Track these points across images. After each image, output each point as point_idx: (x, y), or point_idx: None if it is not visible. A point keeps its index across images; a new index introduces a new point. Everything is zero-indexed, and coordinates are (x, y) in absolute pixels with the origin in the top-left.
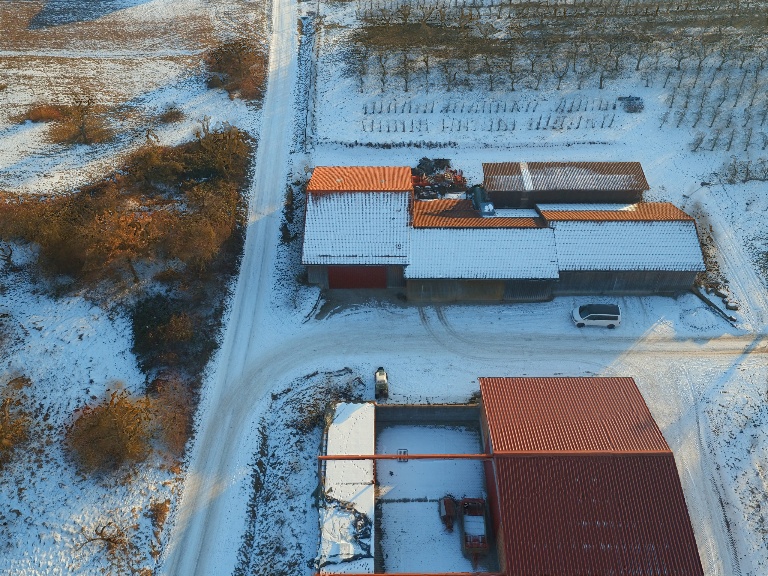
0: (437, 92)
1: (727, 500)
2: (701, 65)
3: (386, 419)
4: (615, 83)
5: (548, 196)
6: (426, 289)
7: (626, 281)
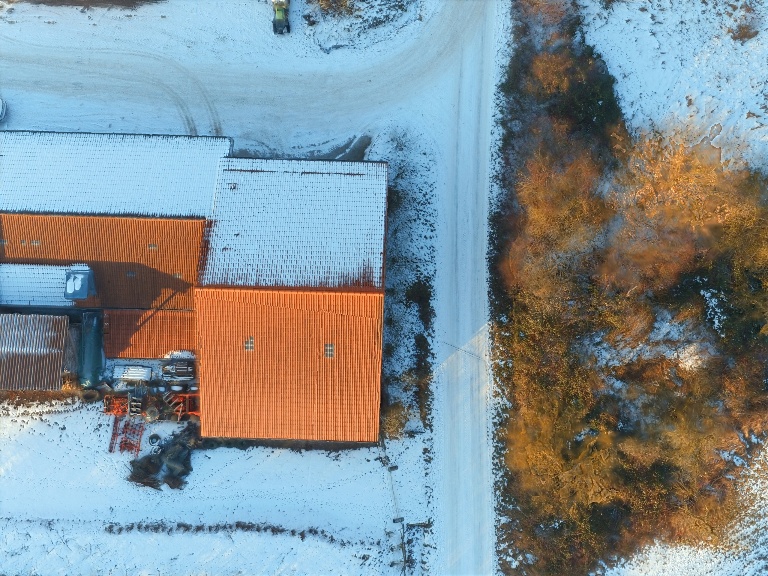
0: None
1: None
2: None
3: None
4: None
5: None
6: None
7: None
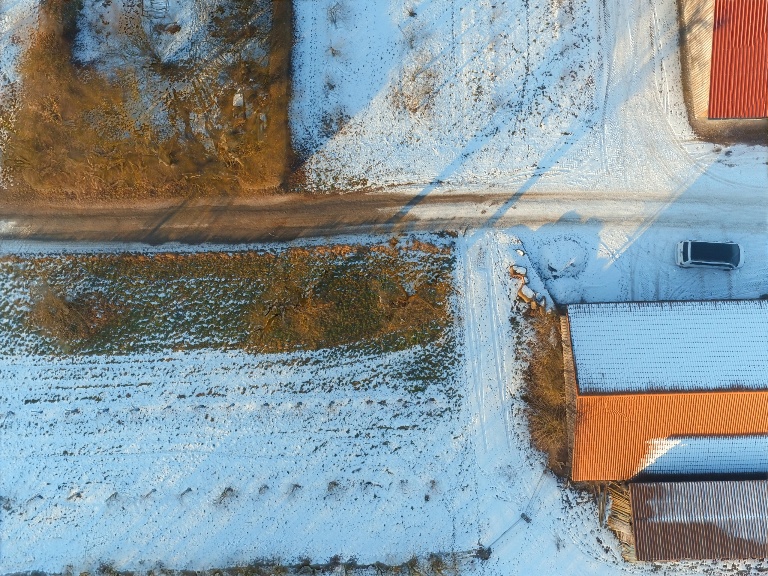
0: None
1: (600, 2)
2: None
3: None
4: None
5: None
6: None
7: None
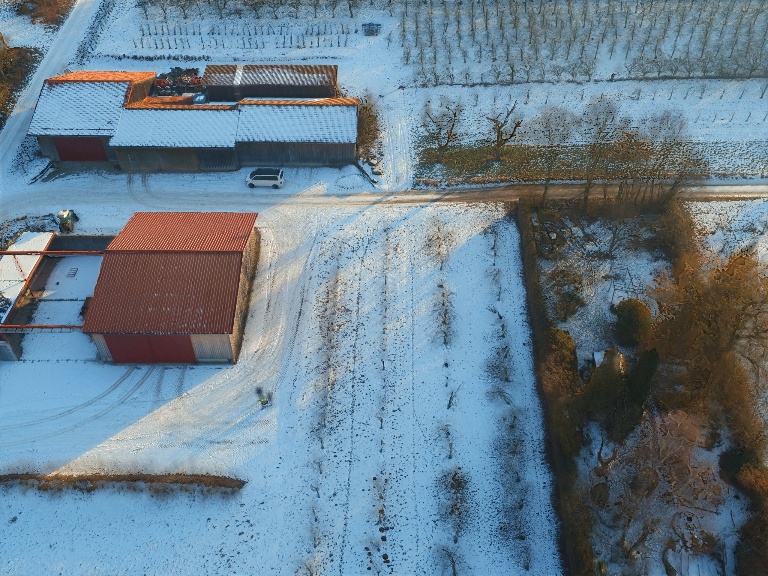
0: (211, 19)
1: (306, 298)
2: (446, 0)
3: (70, 249)
4: (366, 13)
5: (256, 91)
6: (133, 158)
7: (298, 154)
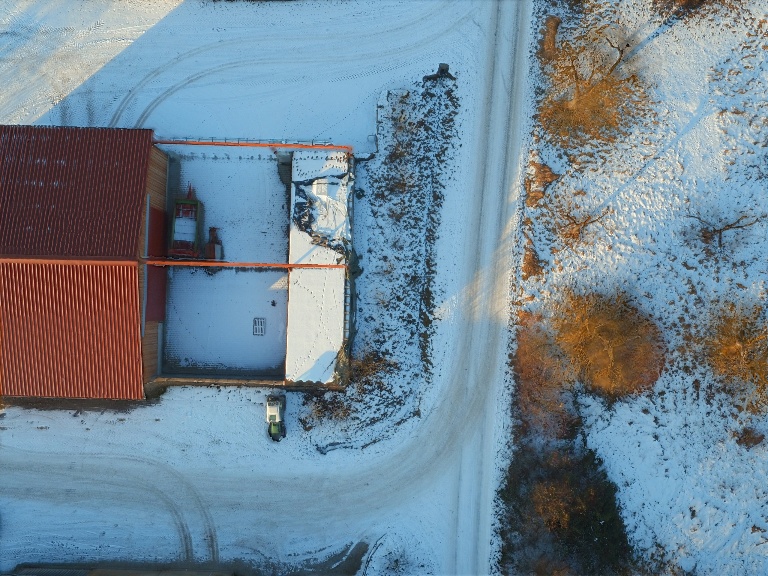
0: None
1: None
2: None
3: None
4: None
5: None
6: None
7: None
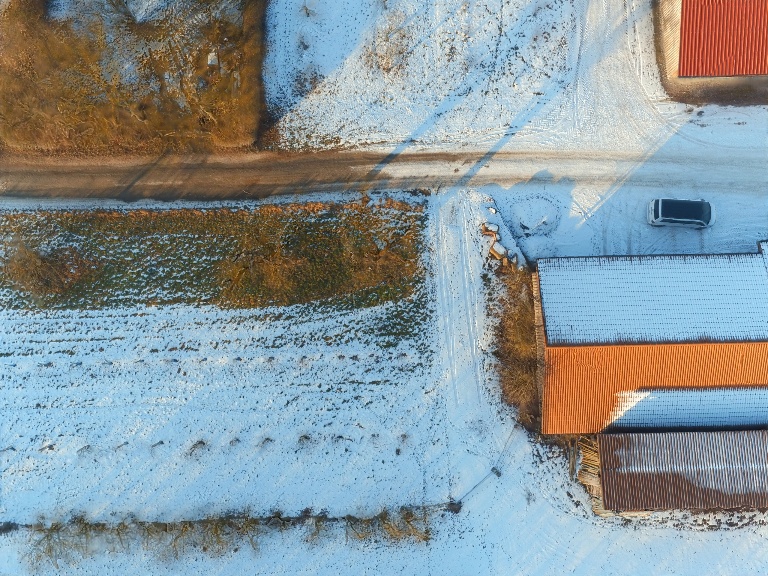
0: None
1: None
2: None
3: None
4: None
5: None
6: None
7: None
